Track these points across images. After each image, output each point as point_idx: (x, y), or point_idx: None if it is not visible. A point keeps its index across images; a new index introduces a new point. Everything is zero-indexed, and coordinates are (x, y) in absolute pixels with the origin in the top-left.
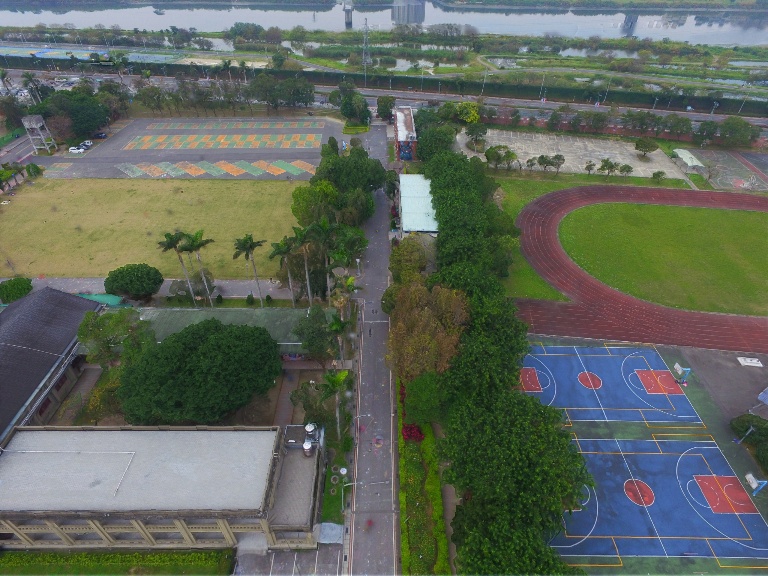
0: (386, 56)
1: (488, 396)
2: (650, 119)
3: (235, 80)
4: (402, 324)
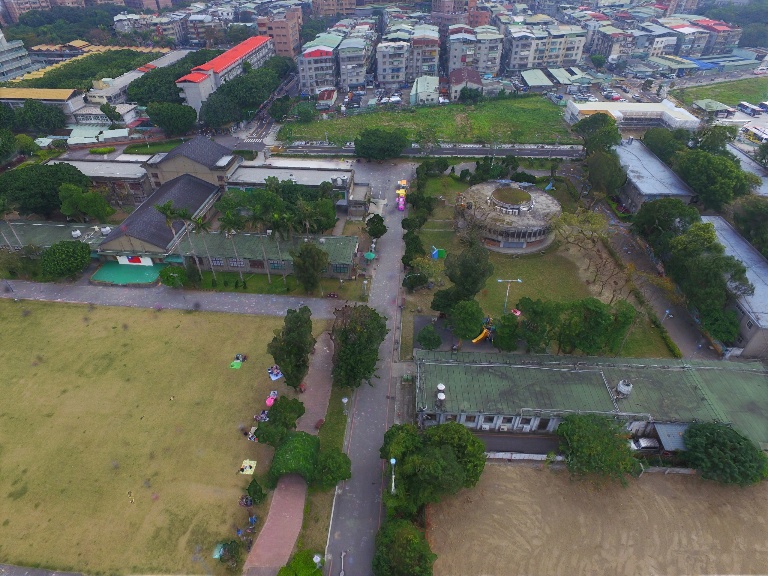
0: None
1: None
2: None
3: None
4: None
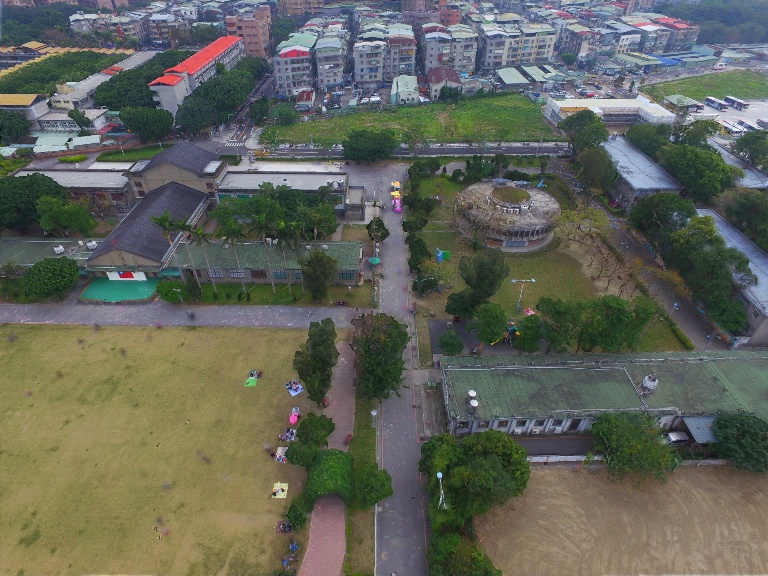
0: None
1: None
2: None
3: None
4: None
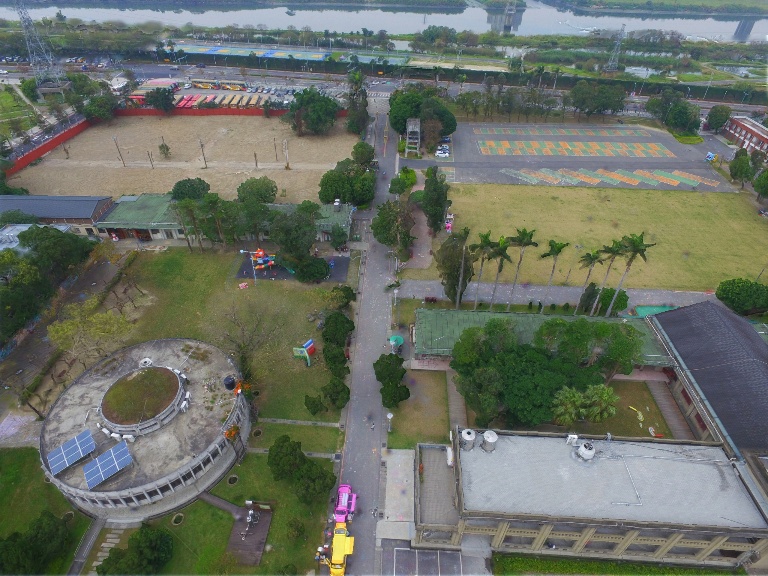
0: None
1: None
2: None
3: (541, 86)
4: None
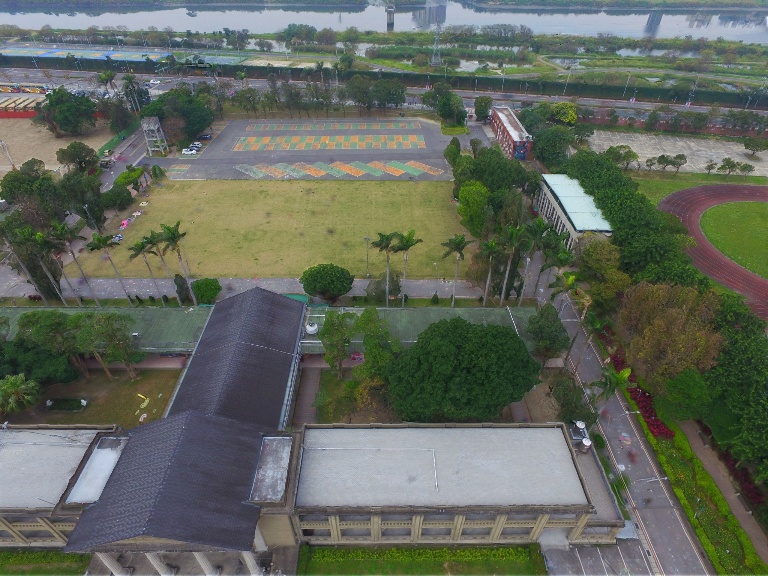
0: (446, 57)
1: (765, 393)
2: (752, 118)
3: (326, 81)
4: (661, 322)
